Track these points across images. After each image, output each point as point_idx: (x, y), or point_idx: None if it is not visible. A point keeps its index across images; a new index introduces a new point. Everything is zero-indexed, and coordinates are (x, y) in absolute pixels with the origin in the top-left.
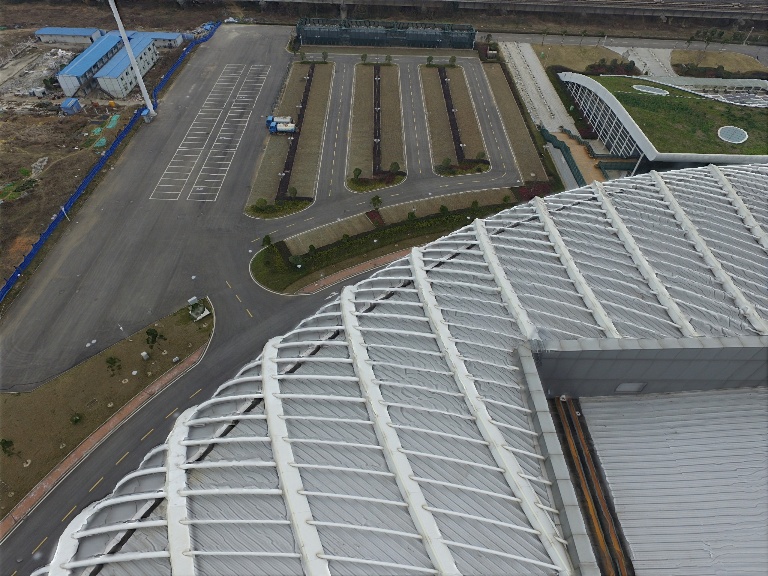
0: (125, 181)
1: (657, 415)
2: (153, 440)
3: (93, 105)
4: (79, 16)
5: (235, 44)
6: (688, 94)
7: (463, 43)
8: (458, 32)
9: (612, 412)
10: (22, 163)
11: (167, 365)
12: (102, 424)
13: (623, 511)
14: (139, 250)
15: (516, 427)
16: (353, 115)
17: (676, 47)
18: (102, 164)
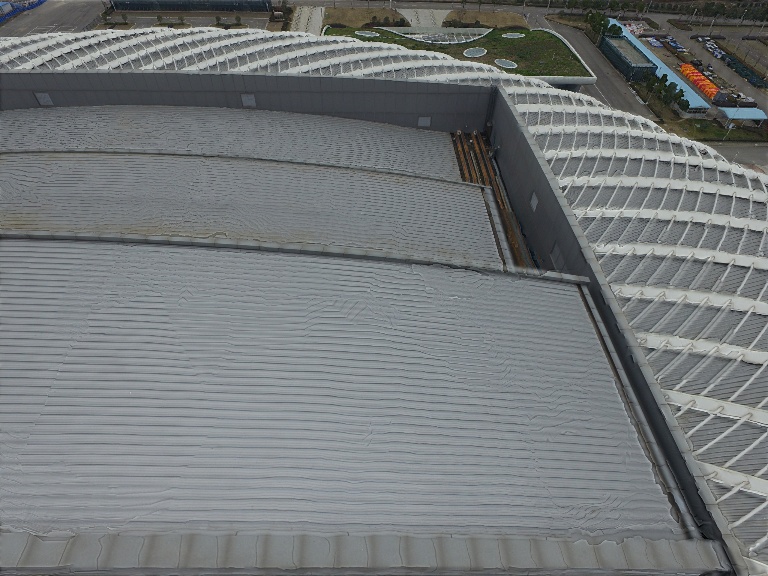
0: None
1: None
2: None
3: None
4: None
5: (56, 11)
6: (396, 36)
7: (260, 7)
8: None
9: None
10: None
11: None
12: None
13: None
14: None
15: None
16: None
17: (458, 8)
18: None
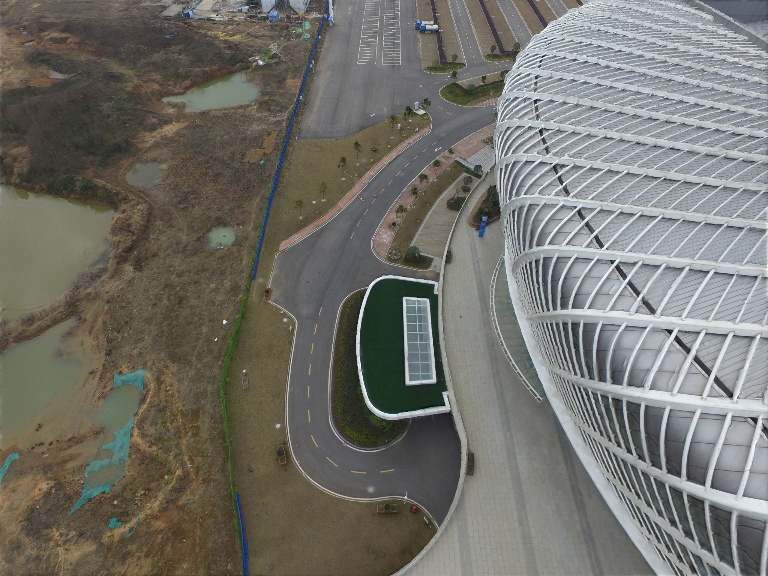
0: (336, 55)
1: None
2: (420, 159)
3: (287, 17)
4: None
5: None
6: None
7: None
8: None
9: None
10: (262, 46)
11: (412, 132)
12: (388, 153)
13: None
14: (366, 86)
15: (682, 5)
16: (473, 23)
17: None
18: (315, 46)
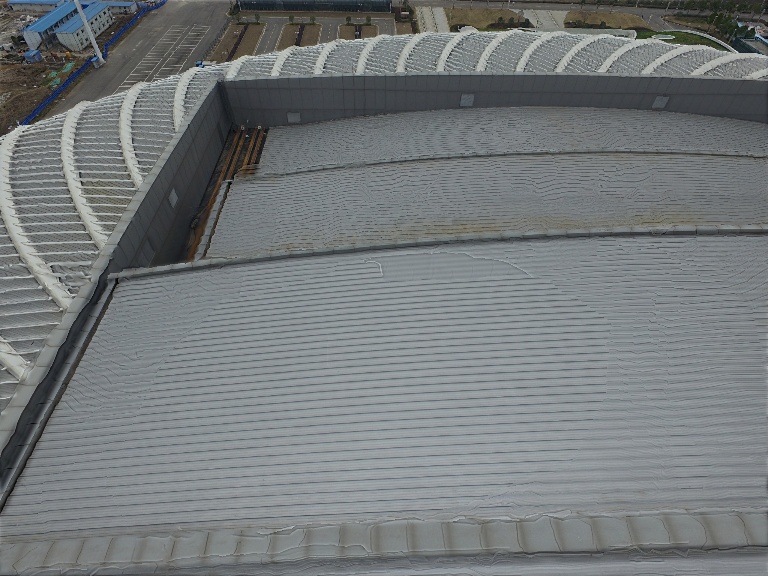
0: None
1: (306, 131)
2: None
3: (52, 56)
4: None
5: (182, 10)
6: None
7: (382, 7)
8: None
9: (283, 131)
10: None
11: None
12: None
13: (262, 161)
14: None
15: (192, 105)
16: None
17: (573, 9)
18: (55, 96)
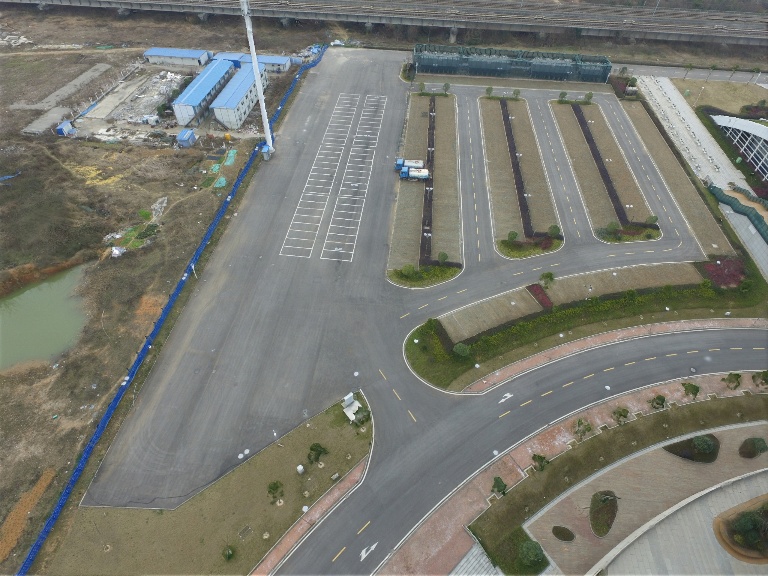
0: (251, 231)
1: None
2: None
3: (208, 137)
4: (183, 35)
5: (346, 70)
6: None
7: (595, 76)
8: (592, 64)
9: None
10: (141, 203)
11: (326, 483)
12: (258, 563)
13: None
14: (276, 321)
15: None
16: (488, 159)
17: None
18: (225, 209)
